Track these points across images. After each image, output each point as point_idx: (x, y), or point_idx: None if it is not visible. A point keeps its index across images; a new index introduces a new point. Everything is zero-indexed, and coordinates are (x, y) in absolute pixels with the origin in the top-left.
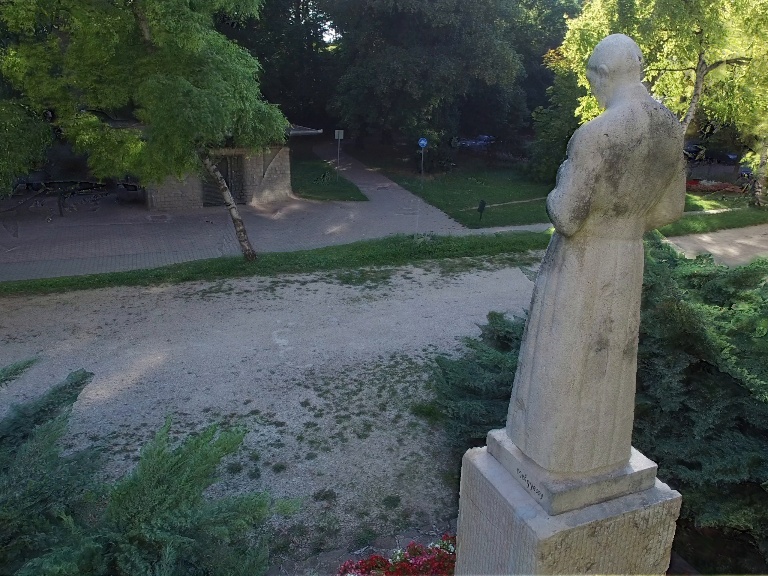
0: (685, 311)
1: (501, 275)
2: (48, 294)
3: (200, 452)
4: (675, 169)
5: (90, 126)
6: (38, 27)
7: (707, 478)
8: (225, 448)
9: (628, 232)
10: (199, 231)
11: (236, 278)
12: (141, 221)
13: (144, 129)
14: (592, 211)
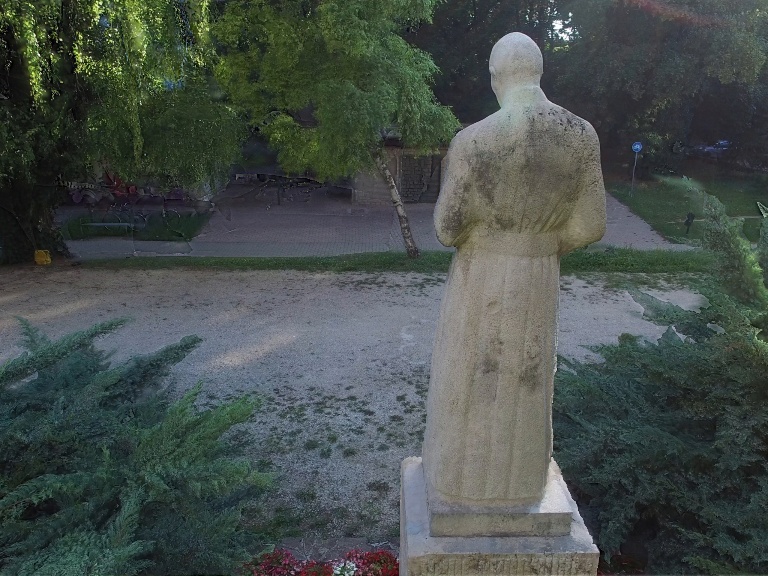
0: (762, 354)
1: (674, 296)
2: (233, 271)
3: (214, 417)
4: (578, 181)
5: (283, 126)
6: (242, 40)
7: (748, 555)
8: (235, 417)
9: (520, 248)
10: (389, 226)
11: (394, 272)
12: (342, 213)
13: (321, 129)
14: (474, 222)
